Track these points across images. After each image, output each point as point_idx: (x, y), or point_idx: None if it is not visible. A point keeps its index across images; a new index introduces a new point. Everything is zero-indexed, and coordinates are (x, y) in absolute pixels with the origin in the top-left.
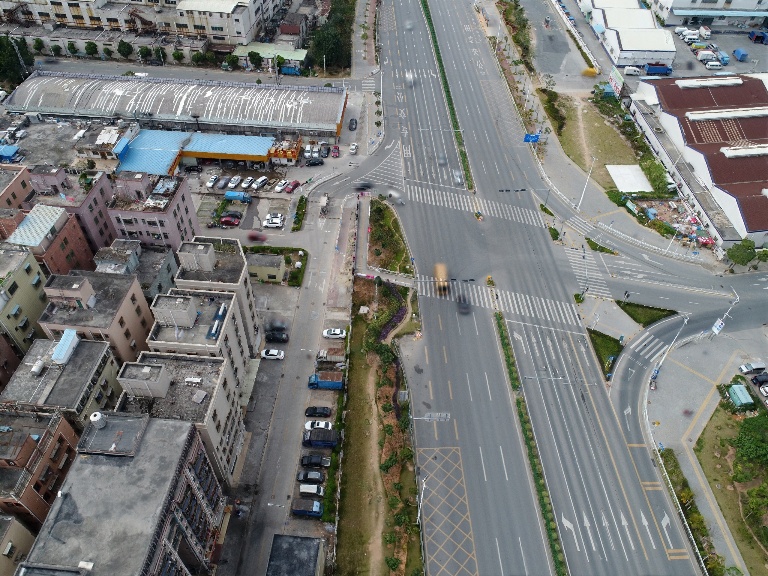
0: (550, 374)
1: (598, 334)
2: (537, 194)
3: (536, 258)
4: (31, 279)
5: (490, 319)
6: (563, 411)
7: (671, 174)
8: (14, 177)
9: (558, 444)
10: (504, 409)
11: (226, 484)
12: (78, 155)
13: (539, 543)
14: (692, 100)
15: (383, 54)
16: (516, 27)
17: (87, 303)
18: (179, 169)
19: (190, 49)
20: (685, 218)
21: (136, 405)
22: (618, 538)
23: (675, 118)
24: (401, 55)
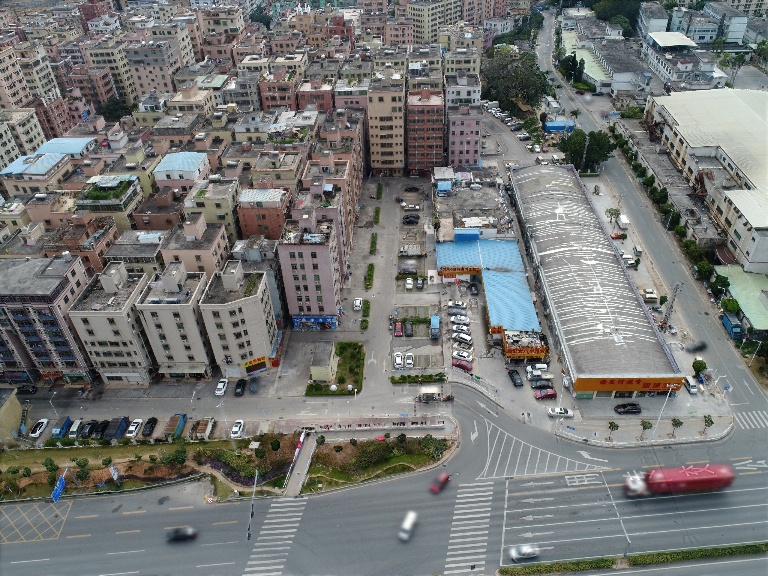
0: None
1: None
2: None
3: None
4: (219, 212)
5: None
6: None
7: None
8: None
9: None
10: None
11: None
12: None
13: None
14: None
15: None
16: None
17: (187, 236)
18: (471, 280)
19: (693, 233)
20: None
21: None
22: None
23: None
24: None
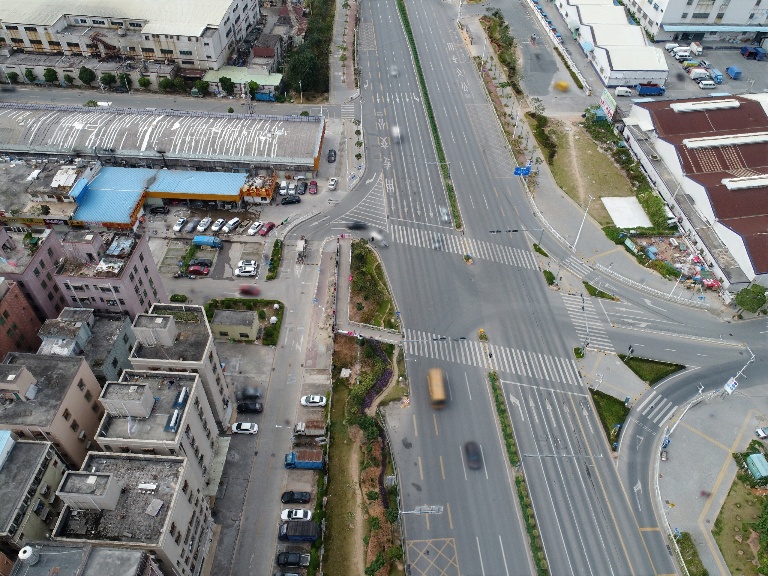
0: (551, 445)
1: (601, 395)
2: (530, 232)
3: (531, 306)
4: None
5: (484, 380)
6: (567, 490)
7: (670, 206)
8: None
9: (563, 531)
10: (502, 489)
11: None
12: (32, 199)
13: None
14: (688, 125)
15: (363, 76)
16: (501, 45)
17: (26, 395)
18: (144, 211)
19: (157, 75)
20: (687, 256)
21: (80, 521)
22: None
23: (672, 146)
24: (382, 77)
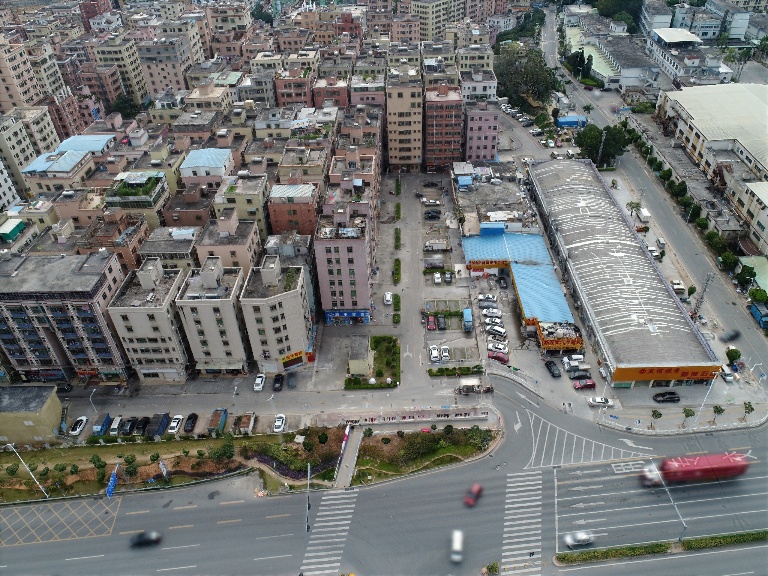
0: None
1: None
2: None
3: None
4: (249, 207)
5: None
6: None
7: None
8: None
9: None
10: None
11: None
12: None
13: None
14: None
15: None
16: None
17: (221, 232)
18: (499, 273)
19: (715, 225)
20: None
21: None
22: None
23: None
24: None
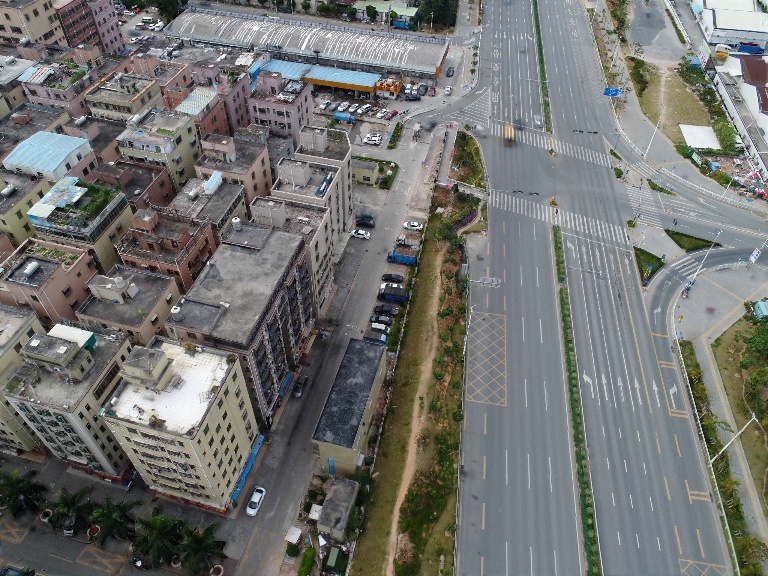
0: (593, 275)
1: (643, 251)
2: (609, 141)
3: (598, 190)
4: (190, 138)
5: (548, 230)
6: (600, 303)
7: (742, 137)
8: (179, 72)
9: (590, 325)
10: (548, 294)
11: (315, 314)
12: None
13: (561, 388)
14: None
15: (486, 18)
16: (616, 3)
17: (230, 158)
18: None
19: None
20: (747, 173)
21: None
22: (629, 395)
23: (754, 87)
24: (502, 20)
